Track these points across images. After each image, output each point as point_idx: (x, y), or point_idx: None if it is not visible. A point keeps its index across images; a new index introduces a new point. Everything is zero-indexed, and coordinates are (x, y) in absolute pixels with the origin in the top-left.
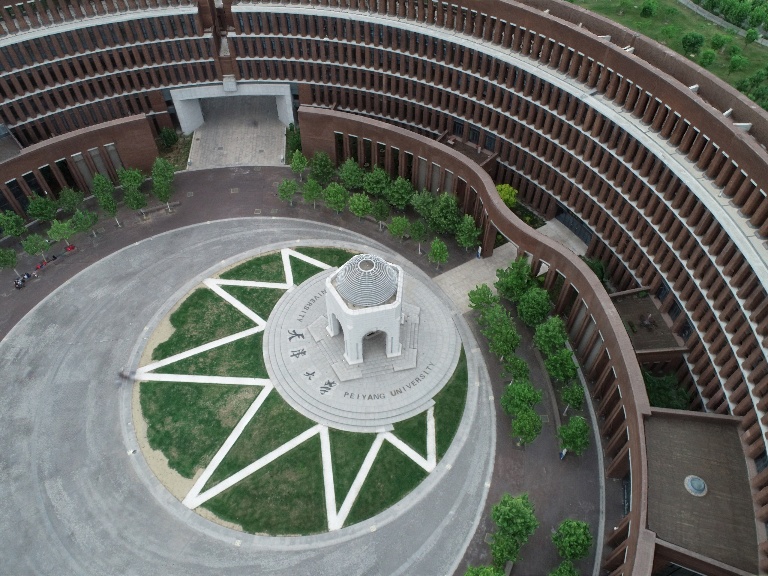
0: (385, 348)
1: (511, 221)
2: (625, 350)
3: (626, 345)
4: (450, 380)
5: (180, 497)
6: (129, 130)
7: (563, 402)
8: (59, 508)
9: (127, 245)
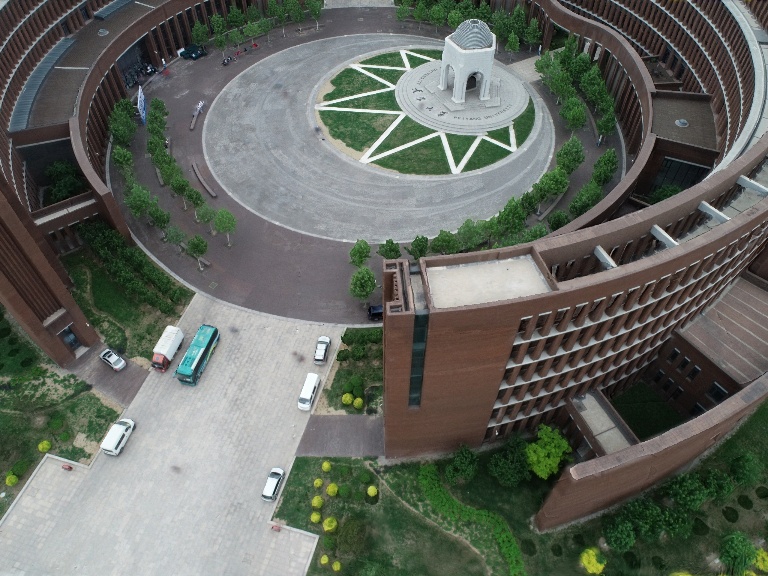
0: (479, 96)
1: (565, 12)
2: (641, 67)
3: (642, 65)
4: (523, 113)
5: (357, 159)
6: None
7: (600, 112)
8: (283, 161)
9: (292, 46)
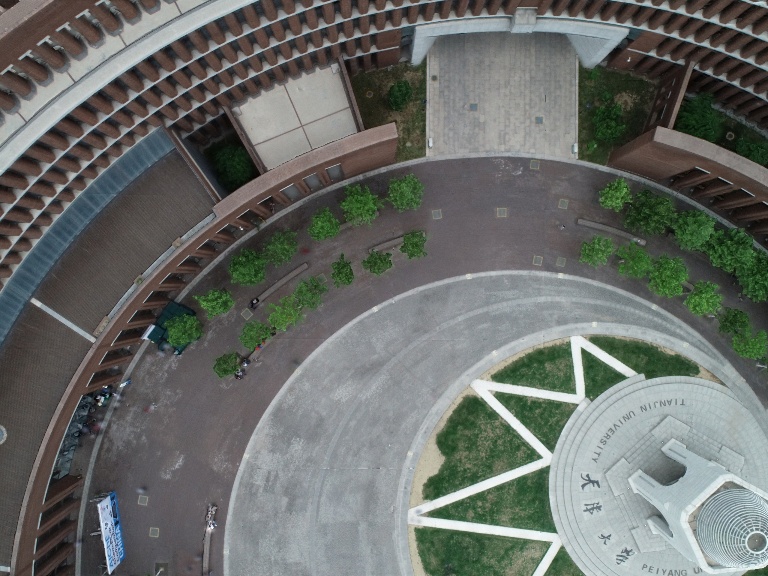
0: None
1: None
2: None
3: None
4: None
5: None
6: (367, 149)
7: None
8: None
9: (363, 311)
